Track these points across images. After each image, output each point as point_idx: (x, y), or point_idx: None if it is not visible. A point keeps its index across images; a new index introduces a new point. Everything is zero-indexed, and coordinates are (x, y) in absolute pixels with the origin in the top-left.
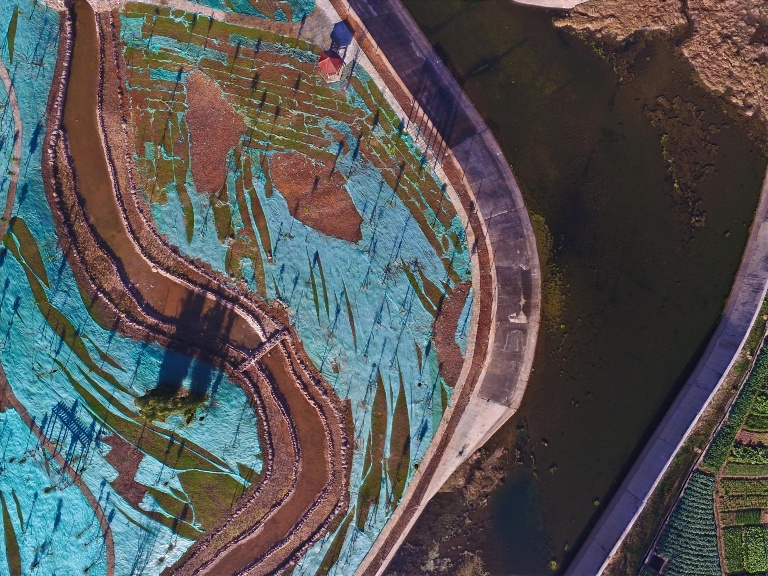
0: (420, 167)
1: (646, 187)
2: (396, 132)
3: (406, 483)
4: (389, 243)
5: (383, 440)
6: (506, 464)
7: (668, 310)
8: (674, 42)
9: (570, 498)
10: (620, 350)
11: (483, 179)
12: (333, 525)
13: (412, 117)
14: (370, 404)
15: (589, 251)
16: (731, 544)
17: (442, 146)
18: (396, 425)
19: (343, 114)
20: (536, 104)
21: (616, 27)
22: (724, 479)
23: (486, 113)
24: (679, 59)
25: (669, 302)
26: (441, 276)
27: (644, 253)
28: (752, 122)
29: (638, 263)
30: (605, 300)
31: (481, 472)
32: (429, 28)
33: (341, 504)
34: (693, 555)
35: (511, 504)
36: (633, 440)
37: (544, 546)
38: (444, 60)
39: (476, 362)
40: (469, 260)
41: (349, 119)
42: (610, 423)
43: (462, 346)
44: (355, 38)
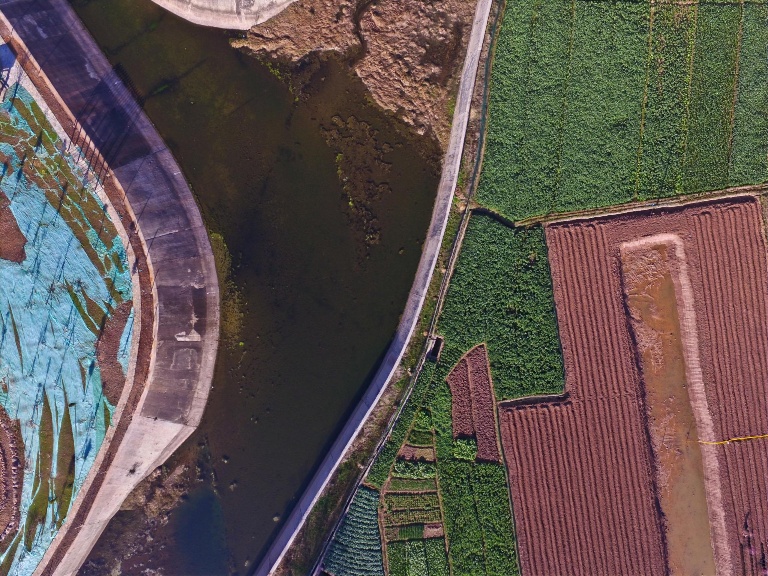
0: (82, 188)
1: (323, 205)
2: (59, 153)
3: (70, 502)
4: (52, 263)
5: (50, 460)
6: (187, 481)
7: (345, 327)
8: (348, 63)
9: (251, 514)
10: (299, 367)
11: (150, 199)
12: (4, 545)
13: (74, 138)
14: (37, 424)
15: (267, 269)
16: (394, 559)
17: (104, 167)
18: (62, 445)
19: (7, 136)
20: (215, 124)
21: (290, 48)
22: (388, 494)
23: (166, 133)
24: (353, 79)
25: (346, 319)
26: (104, 296)
27: (321, 271)
28: (424, 141)
29: (316, 281)
30: (283, 317)
31: (161, 490)
32: (110, 49)
33: (12, 524)
34: (357, 570)
35: (197, 521)
36: (312, 456)
37: (226, 563)
38: (124, 81)
39: (138, 381)
40: (130, 280)
41: (13, 141)
42: (290, 439)
43: (124, 365)
44: (18, 60)
